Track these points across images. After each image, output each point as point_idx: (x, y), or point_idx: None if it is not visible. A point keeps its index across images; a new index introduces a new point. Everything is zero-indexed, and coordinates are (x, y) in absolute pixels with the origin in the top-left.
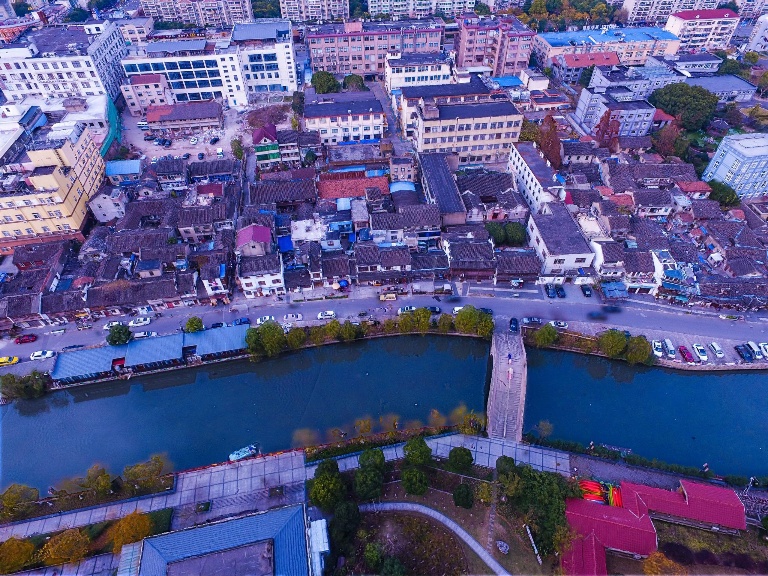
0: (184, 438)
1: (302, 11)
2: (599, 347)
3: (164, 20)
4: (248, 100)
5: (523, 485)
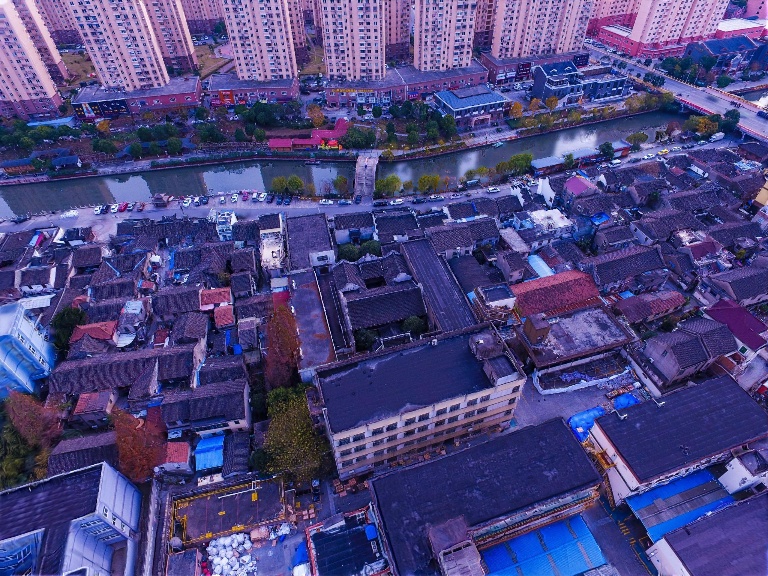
0: None
1: None
2: None
3: None
4: None
5: None
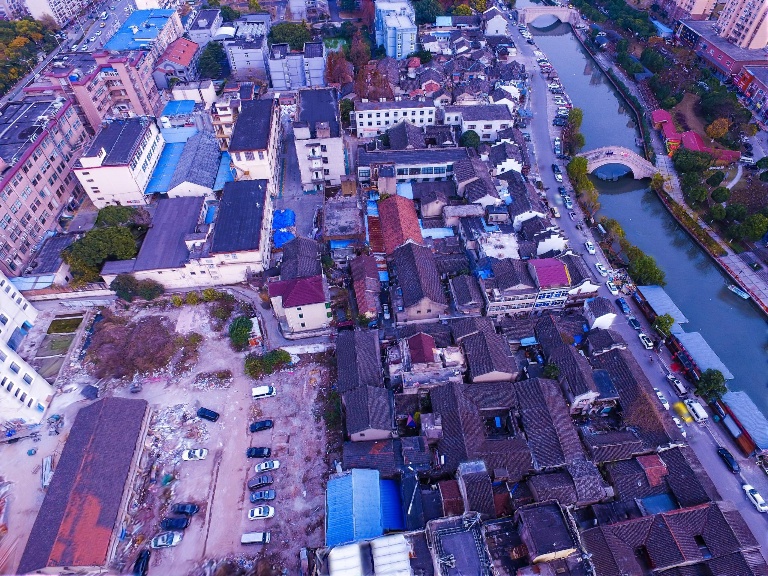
0: (747, 336)
1: None
2: None
3: None
4: None
5: None
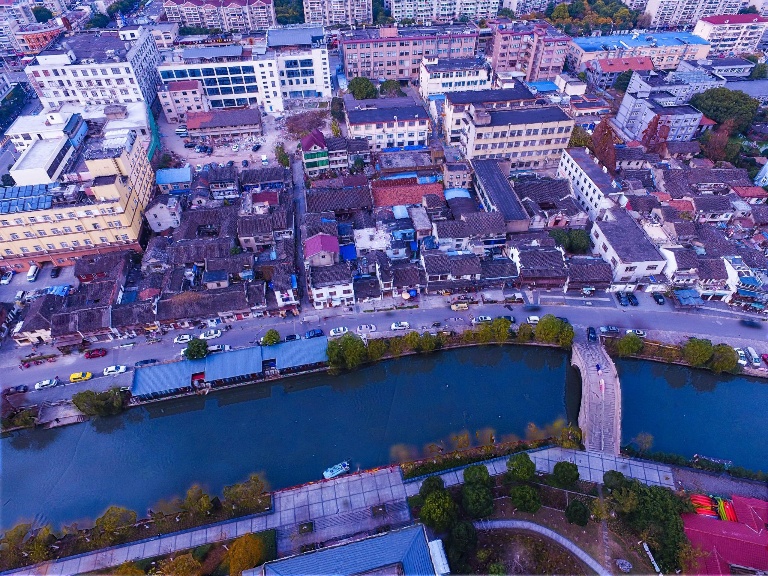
0: (272, 455)
1: (326, 16)
2: (683, 356)
3: (187, 25)
4: (283, 106)
5: (636, 501)
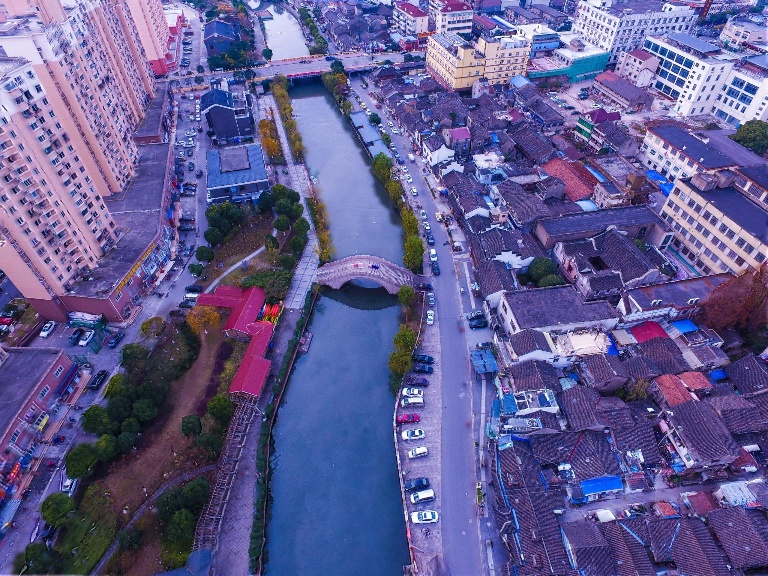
0: None
1: None
2: None
3: None
4: (695, 115)
5: None
